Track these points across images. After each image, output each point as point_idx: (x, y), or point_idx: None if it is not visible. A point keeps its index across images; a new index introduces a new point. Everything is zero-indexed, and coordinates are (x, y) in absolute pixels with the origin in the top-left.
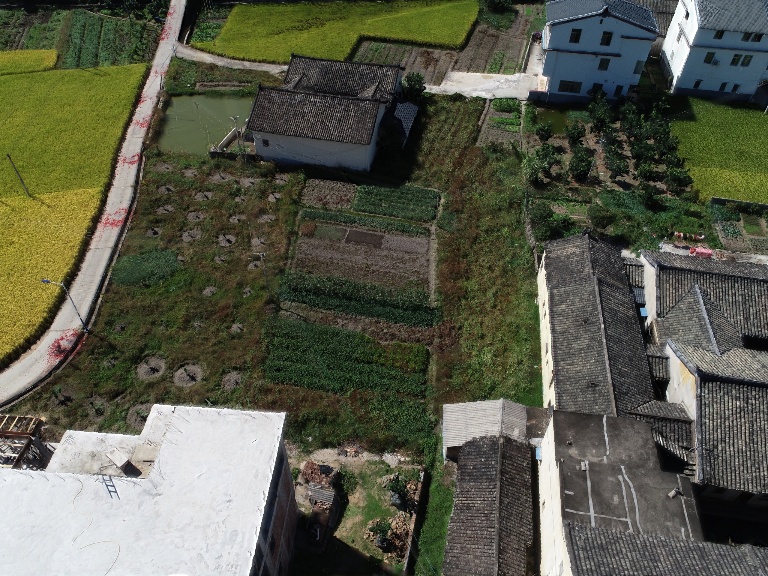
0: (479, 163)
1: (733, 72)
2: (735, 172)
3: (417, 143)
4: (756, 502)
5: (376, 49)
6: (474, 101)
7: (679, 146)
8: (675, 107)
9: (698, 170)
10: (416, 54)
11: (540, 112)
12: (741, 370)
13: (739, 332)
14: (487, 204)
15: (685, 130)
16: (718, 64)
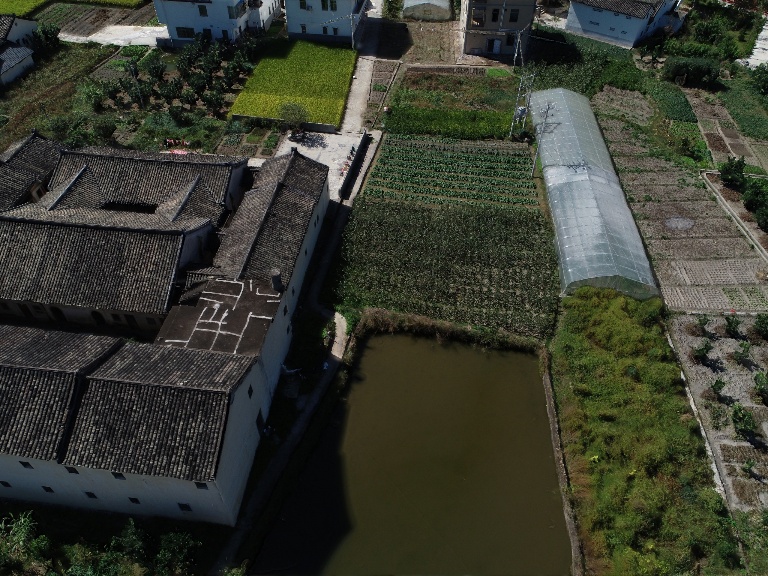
0: (60, 95)
1: (328, 16)
2: (277, 96)
3: (18, 80)
4: (38, 316)
5: (61, 9)
6: (106, 48)
7: (250, 78)
8: (278, 48)
9: (246, 95)
10: (94, 12)
11: (166, 56)
12: (40, 216)
13: (106, 200)
14: (39, 125)
15: (268, 66)
16: (311, 9)
